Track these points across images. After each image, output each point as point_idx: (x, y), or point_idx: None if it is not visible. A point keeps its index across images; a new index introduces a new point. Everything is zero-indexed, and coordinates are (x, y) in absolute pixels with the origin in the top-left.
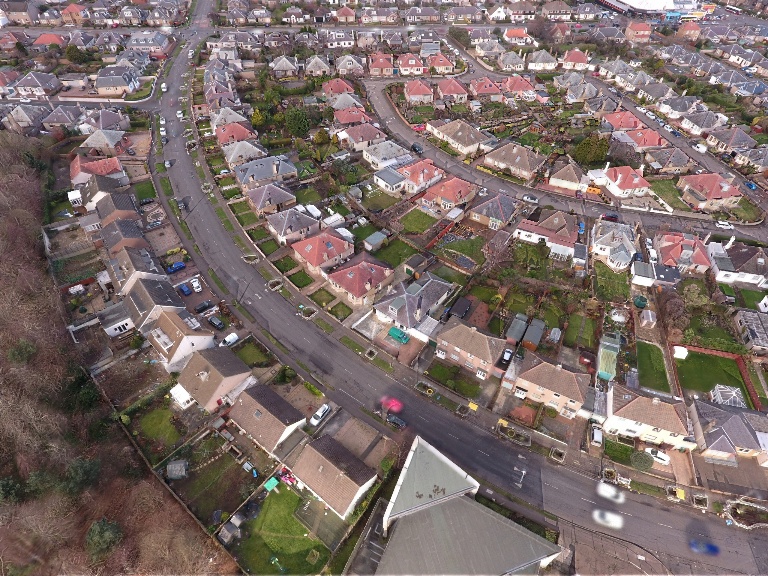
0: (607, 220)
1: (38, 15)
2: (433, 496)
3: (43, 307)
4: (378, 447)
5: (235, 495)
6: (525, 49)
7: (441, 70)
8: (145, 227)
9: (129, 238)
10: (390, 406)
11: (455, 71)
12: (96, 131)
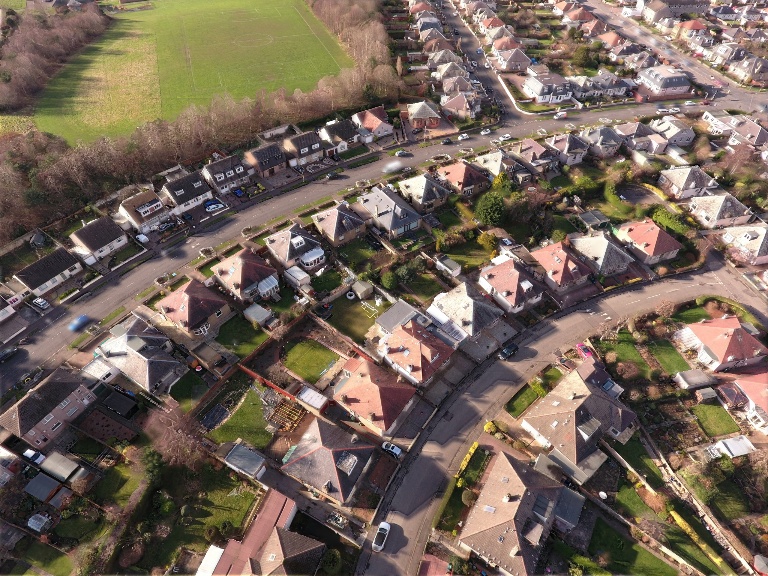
0: None
1: (661, 18)
2: None
3: (176, 143)
4: None
5: (5, 272)
6: None
7: None
8: (297, 166)
9: (253, 155)
10: (28, 350)
11: None
12: (422, 102)
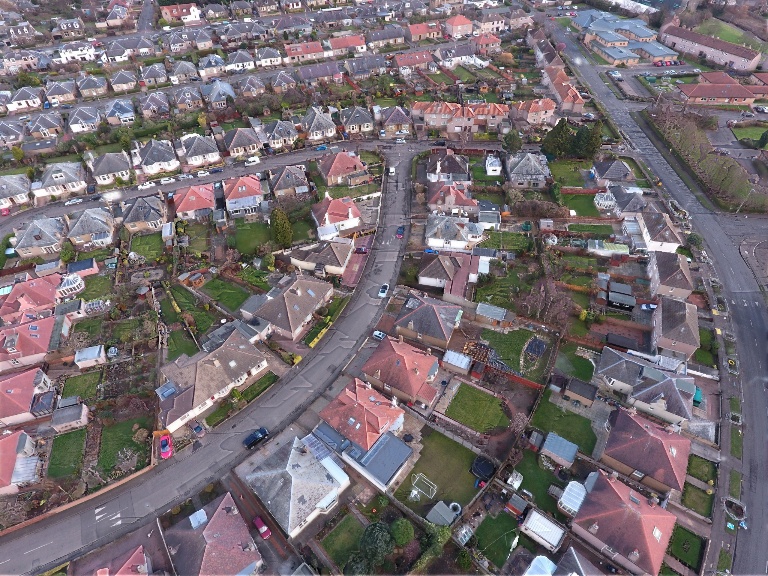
0: (403, 236)
1: None
2: None
3: None
4: None
5: None
6: None
7: None
8: None
9: None
10: None
11: None
12: None
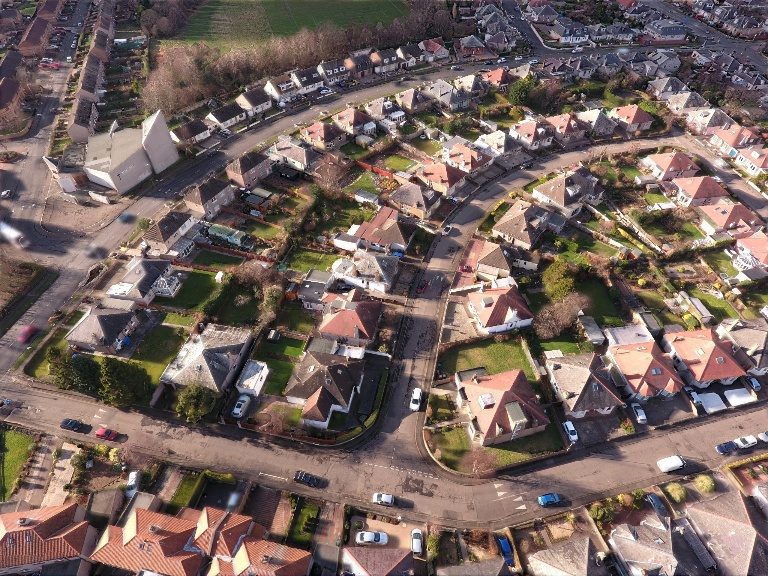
0: None
1: None
2: None
3: (297, 52)
4: (202, 149)
5: None
6: None
7: None
8: None
9: (351, 60)
10: (224, 152)
11: None
12: (471, 35)
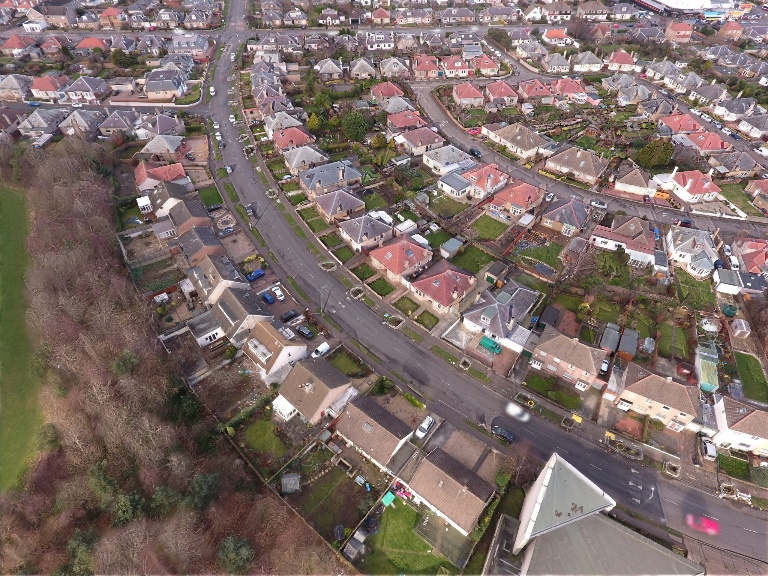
0: None
1: (76, 18)
2: (571, 514)
3: (137, 317)
4: (488, 460)
5: (351, 509)
6: (567, 50)
7: (486, 72)
8: (217, 234)
9: (209, 246)
10: (493, 418)
11: (500, 73)
12: (156, 136)
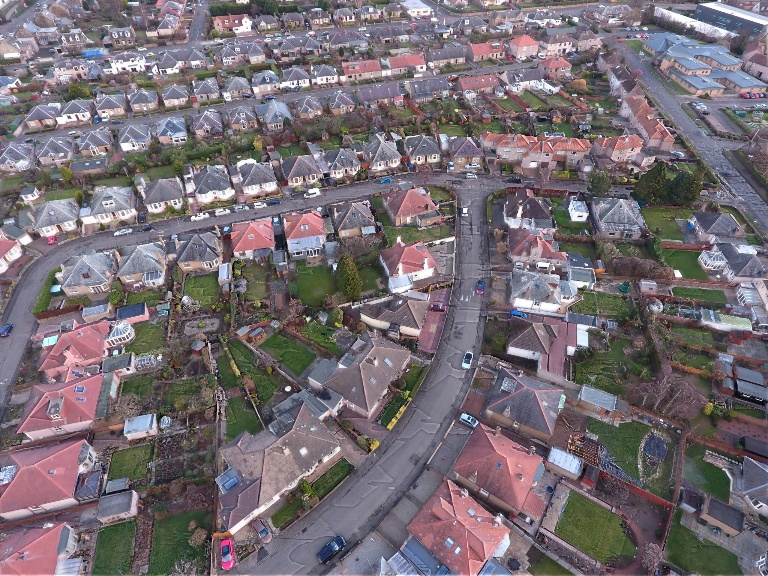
0: (484, 291)
1: None
2: None
3: None
4: None
5: None
6: None
7: None
8: None
9: None
10: None
11: None
12: None
